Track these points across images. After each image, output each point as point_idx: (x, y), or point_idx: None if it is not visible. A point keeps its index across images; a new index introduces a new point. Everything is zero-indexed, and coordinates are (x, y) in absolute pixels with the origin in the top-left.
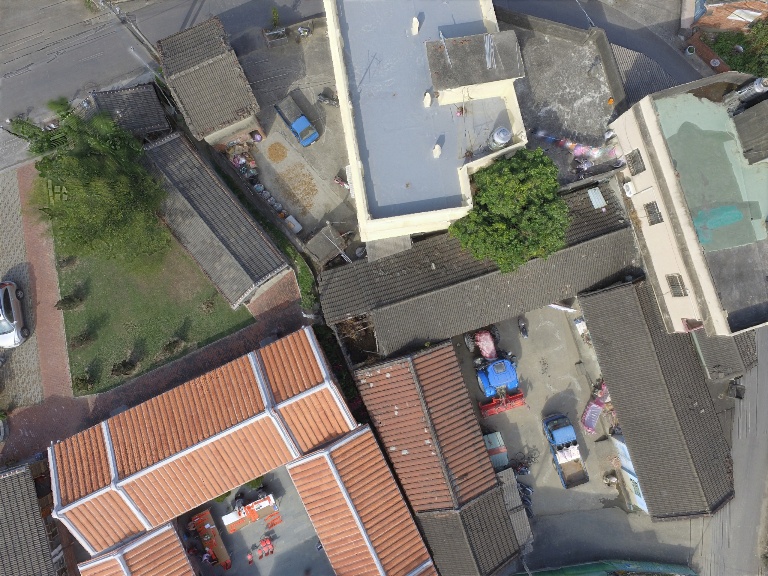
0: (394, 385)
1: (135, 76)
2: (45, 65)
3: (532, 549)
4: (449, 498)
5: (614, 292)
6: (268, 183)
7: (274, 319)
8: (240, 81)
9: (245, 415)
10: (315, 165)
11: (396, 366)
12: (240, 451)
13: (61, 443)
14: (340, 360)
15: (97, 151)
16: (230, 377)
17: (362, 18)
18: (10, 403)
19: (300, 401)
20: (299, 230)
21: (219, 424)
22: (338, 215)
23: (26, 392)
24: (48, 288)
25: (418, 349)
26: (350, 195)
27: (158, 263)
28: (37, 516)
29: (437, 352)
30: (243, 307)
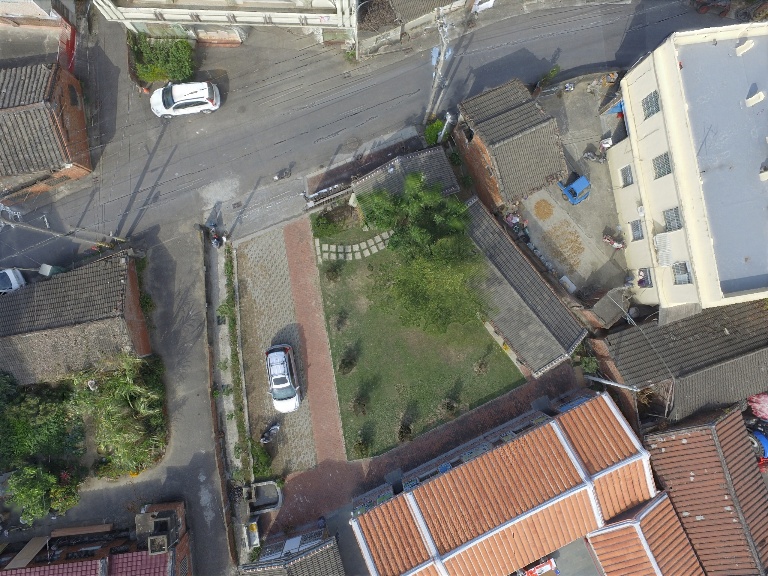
0: (691, 451)
1: (396, 130)
2: (306, 119)
3: None
4: (753, 565)
5: None
6: (535, 241)
7: (544, 379)
8: (555, 148)
9: (562, 487)
10: (580, 223)
11: (695, 433)
12: (552, 522)
13: (365, 515)
14: None
15: (453, 228)
16: (536, 446)
17: (696, 89)
18: (284, 468)
19: (614, 472)
20: (573, 290)
21: (535, 496)
22: (605, 273)
23: (300, 456)
24: (319, 350)
25: (707, 413)
26: (617, 253)
27: None
28: None
29: (730, 417)
30: (514, 368)
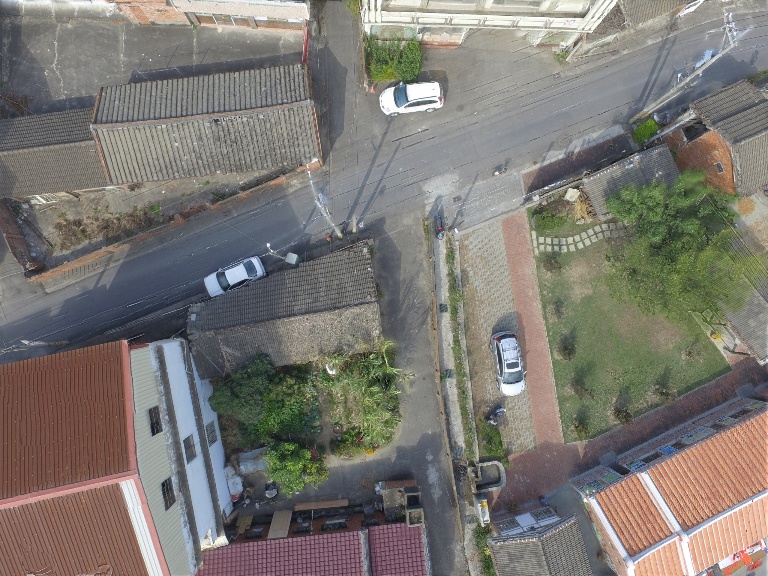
0: None
1: (603, 129)
2: (520, 117)
3: None
4: None
5: None
6: None
7: (748, 368)
8: None
9: None
10: None
11: None
12: None
13: (602, 493)
14: None
15: None
16: (764, 430)
17: None
18: (505, 449)
19: None
20: None
21: None
22: None
23: (520, 438)
24: (537, 337)
25: None
26: None
27: (639, 313)
28: (587, 564)
29: None
30: (721, 356)
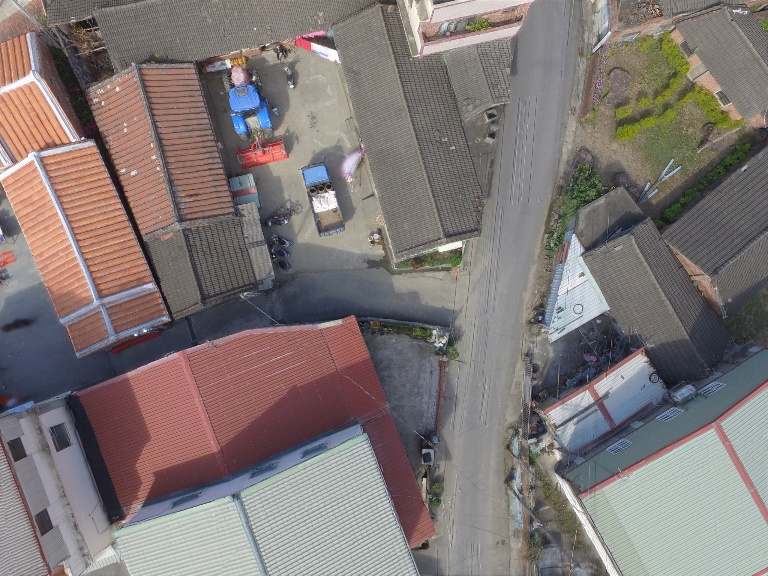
0: (123, 99)
1: None
2: None
3: (271, 285)
4: (171, 213)
5: (362, 15)
6: None
7: None
8: None
9: None
10: None
11: (124, 77)
12: None
13: None
14: (78, 85)
15: None
16: None
17: None
18: None
19: (5, 95)
20: None
21: None
22: None
23: None
24: None
25: None
26: None
27: None
28: None
29: (173, 70)
30: None
